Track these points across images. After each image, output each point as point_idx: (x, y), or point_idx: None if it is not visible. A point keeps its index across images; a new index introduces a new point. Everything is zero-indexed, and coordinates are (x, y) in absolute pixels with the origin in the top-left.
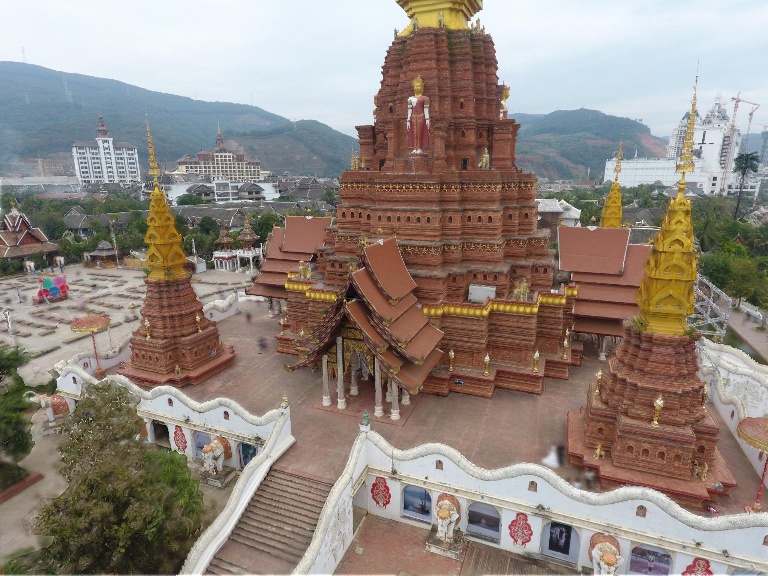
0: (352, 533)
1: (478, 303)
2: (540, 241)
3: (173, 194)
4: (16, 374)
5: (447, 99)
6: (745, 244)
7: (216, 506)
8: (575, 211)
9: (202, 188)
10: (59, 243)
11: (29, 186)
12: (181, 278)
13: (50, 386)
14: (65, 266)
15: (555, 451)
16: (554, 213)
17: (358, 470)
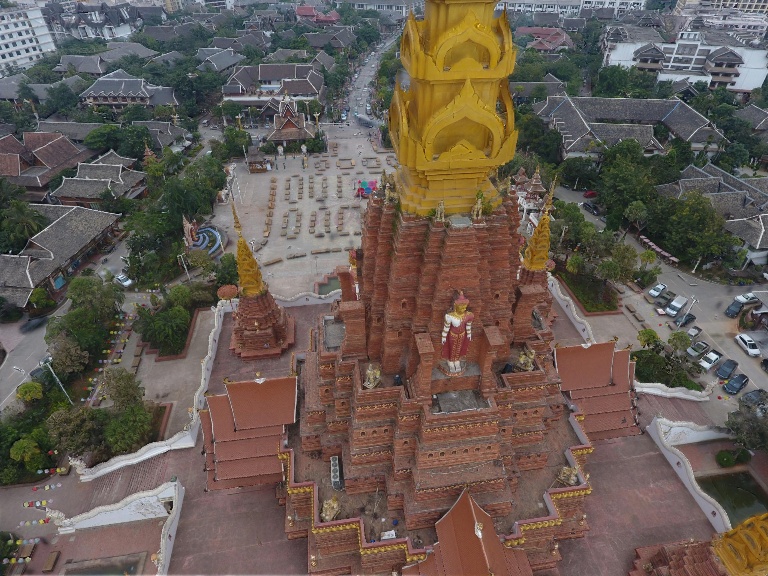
0: (167, 513)
1: None
2: None
3: (616, 55)
4: None
5: (374, 285)
6: None
7: None
8: None
9: (652, 52)
10: None
11: (525, 12)
12: (248, 297)
13: None
14: None
15: None
16: None
17: (166, 494)
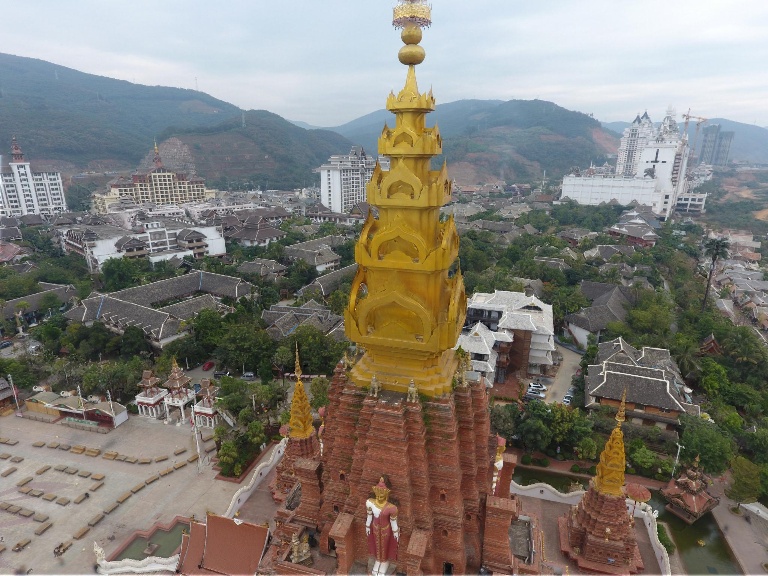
0: None
1: None
2: None
3: (99, 251)
4: None
5: (423, 498)
6: (719, 348)
7: None
8: (548, 317)
9: (133, 242)
10: None
11: None
12: None
13: None
14: None
15: None
16: (527, 330)
17: None
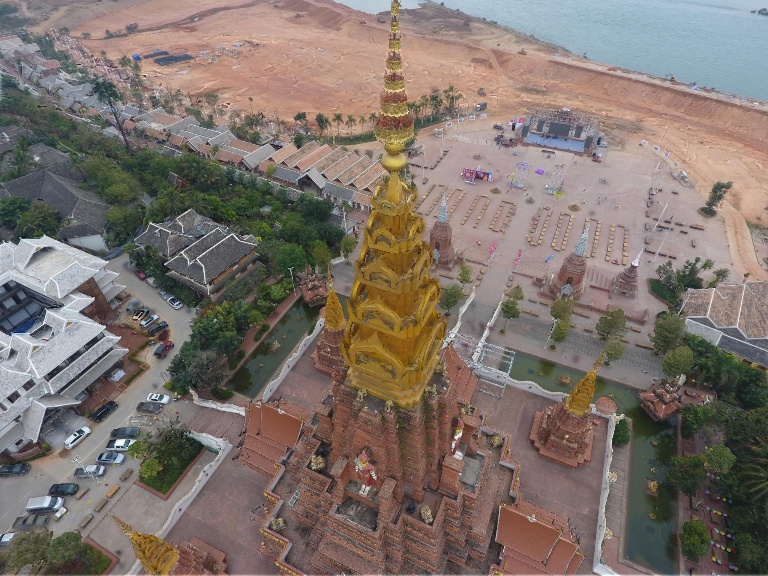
0: None
1: None
2: None
3: None
4: None
5: None
6: (185, 181)
7: None
8: (73, 250)
9: None
10: None
11: None
12: None
13: None
14: None
15: (564, 471)
16: None
17: None
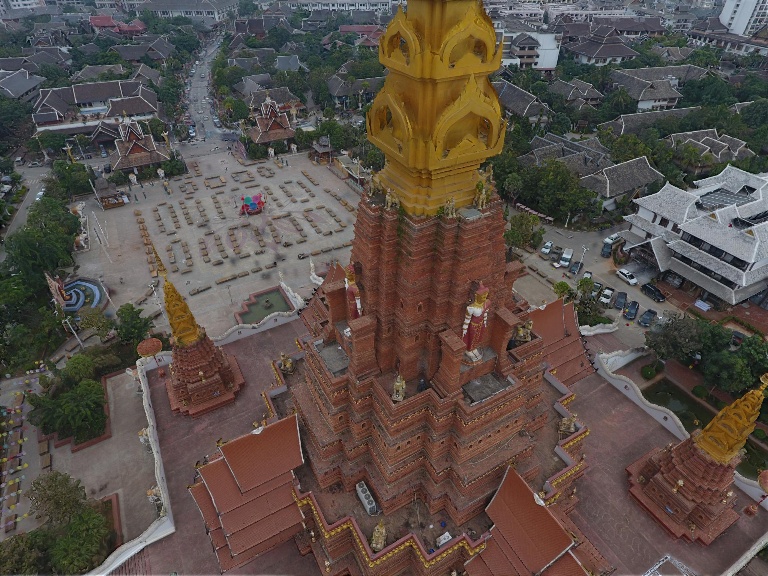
0: None
1: (361, 502)
2: (459, 479)
3: None
4: (137, 343)
5: (382, 295)
6: None
7: (144, 529)
8: None
9: None
10: (296, 131)
11: (342, 11)
12: (187, 346)
13: (168, 343)
14: (297, 153)
15: None
16: None
17: None
